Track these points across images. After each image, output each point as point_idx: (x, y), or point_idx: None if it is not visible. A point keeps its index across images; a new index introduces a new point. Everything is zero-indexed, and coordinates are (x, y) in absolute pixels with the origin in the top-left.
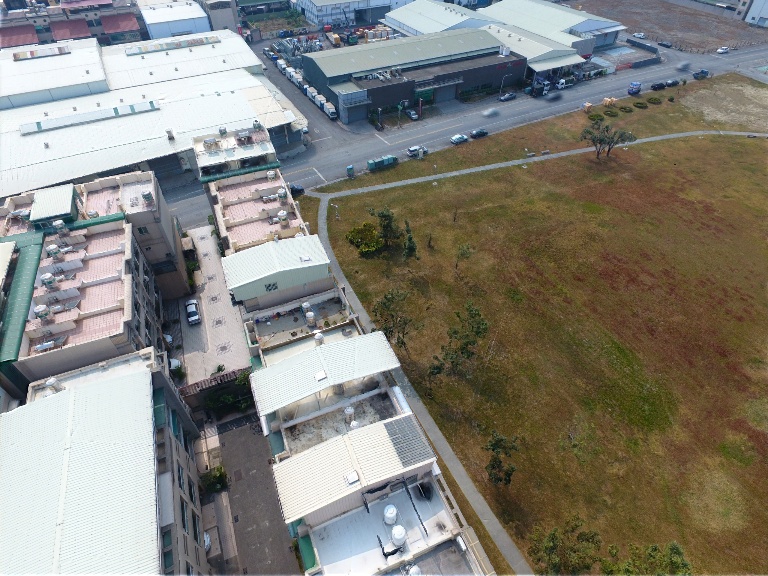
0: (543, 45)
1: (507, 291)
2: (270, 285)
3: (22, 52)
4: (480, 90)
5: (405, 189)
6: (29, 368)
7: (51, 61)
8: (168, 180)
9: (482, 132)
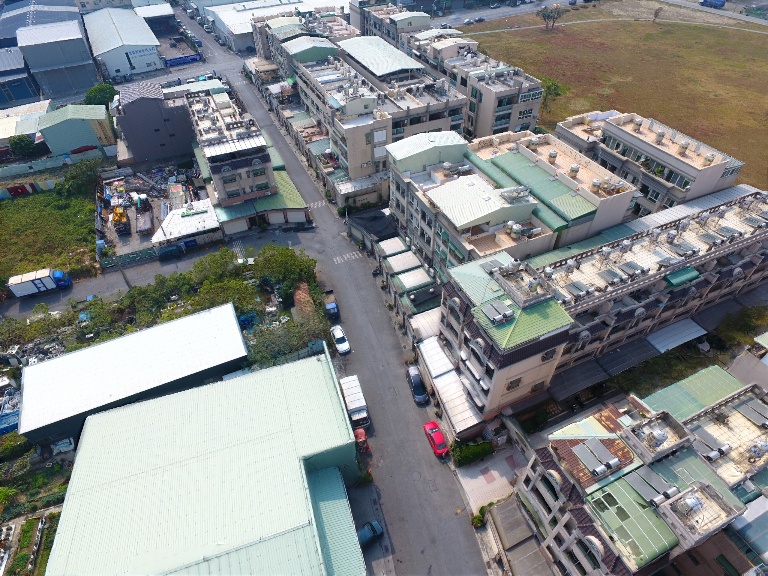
0: None
1: None
2: (409, 23)
3: None
4: (478, 3)
5: None
6: None
7: None
8: None
9: (481, 19)
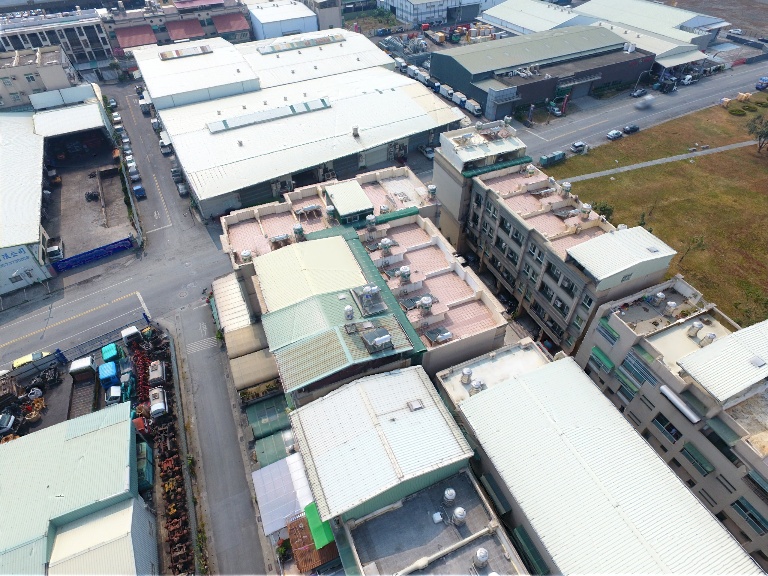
0: (666, 41)
1: (739, 283)
2: (627, 276)
3: (168, 51)
4: (611, 86)
5: (586, 184)
6: (429, 358)
7: (197, 60)
8: (347, 177)
9: (635, 128)
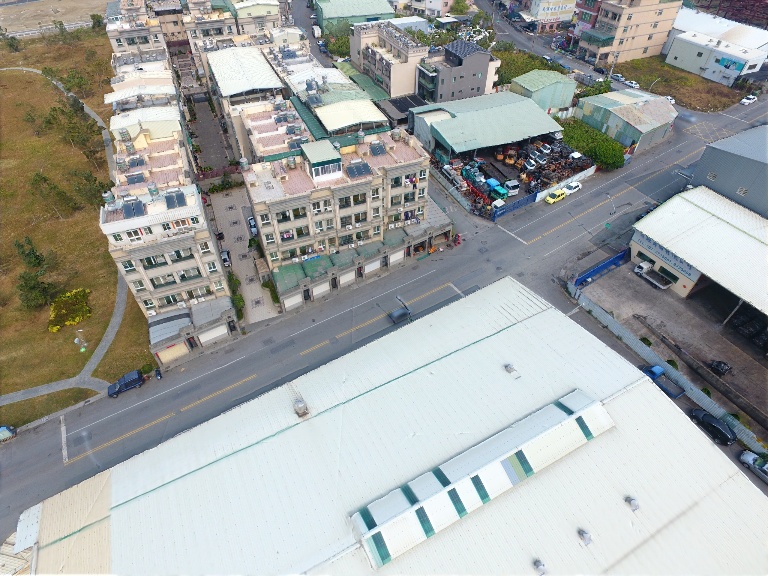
0: None
1: None
2: None
3: None
4: None
5: None
6: None
7: None
8: None
9: None
